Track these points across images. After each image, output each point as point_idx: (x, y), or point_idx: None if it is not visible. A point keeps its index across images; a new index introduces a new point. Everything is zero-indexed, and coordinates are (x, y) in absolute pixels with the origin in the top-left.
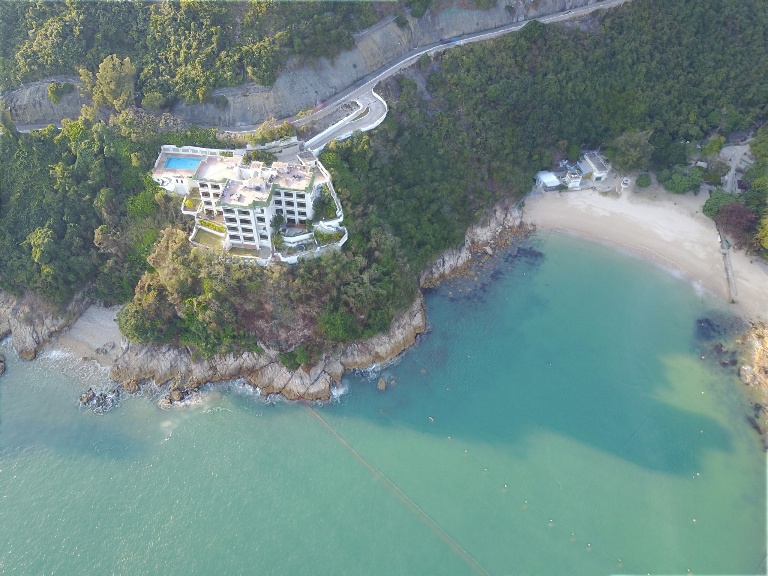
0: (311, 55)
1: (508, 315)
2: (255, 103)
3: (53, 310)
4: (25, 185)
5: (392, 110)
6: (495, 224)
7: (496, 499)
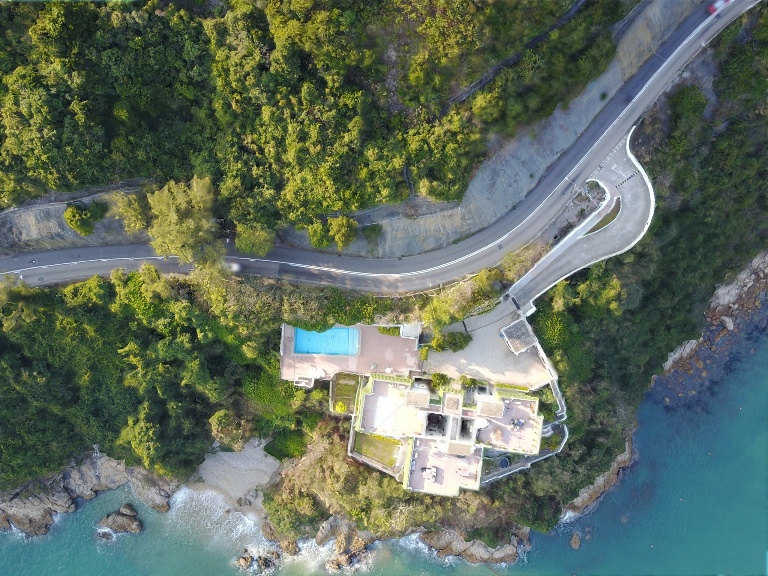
0: (533, 116)
1: (737, 430)
2: (429, 227)
3: (178, 479)
4: (89, 361)
5: (661, 202)
6: (746, 274)
7: None
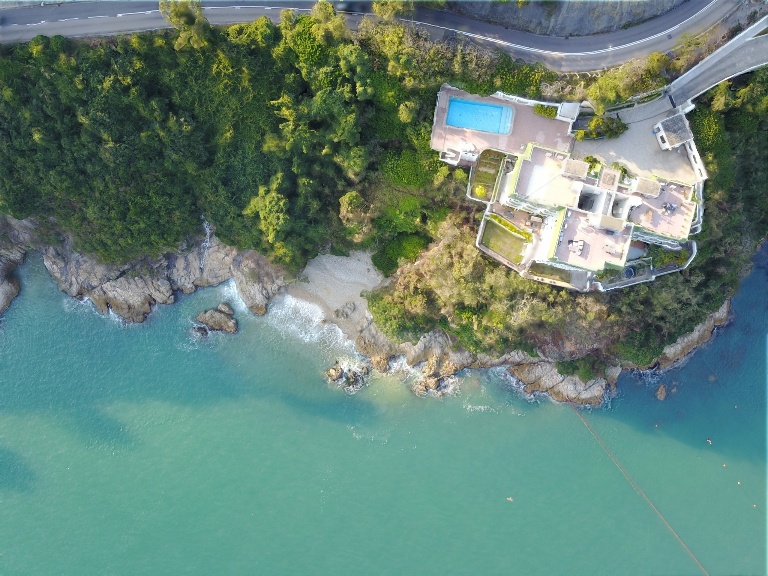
0: None
1: None
2: None
3: (286, 274)
4: (234, 118)
5: None
6: None
7: (756, 534)
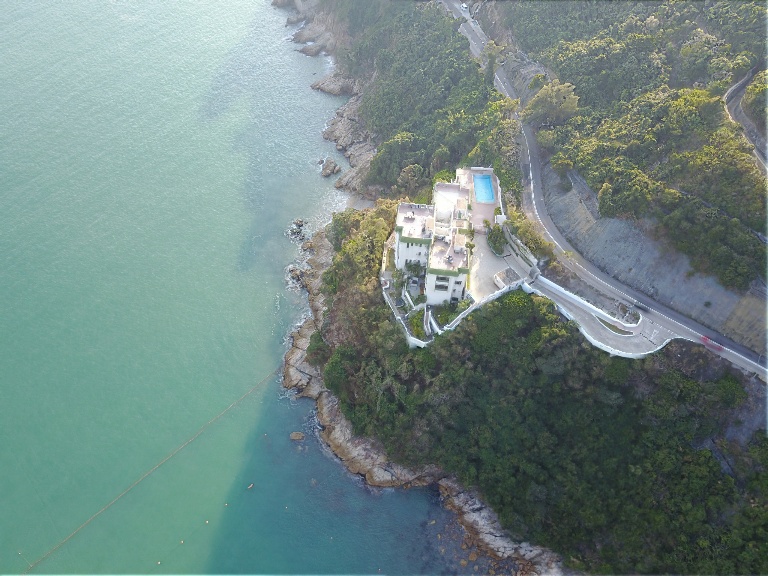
0: (675, 241)
1: None
2: (577, 213)
3: None
4: None
5: (640, 364)
6: None
7: (150, 551)
